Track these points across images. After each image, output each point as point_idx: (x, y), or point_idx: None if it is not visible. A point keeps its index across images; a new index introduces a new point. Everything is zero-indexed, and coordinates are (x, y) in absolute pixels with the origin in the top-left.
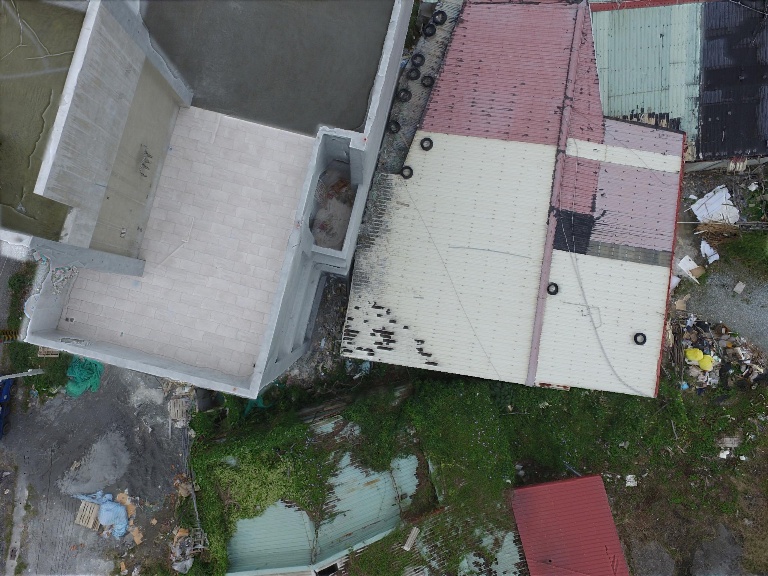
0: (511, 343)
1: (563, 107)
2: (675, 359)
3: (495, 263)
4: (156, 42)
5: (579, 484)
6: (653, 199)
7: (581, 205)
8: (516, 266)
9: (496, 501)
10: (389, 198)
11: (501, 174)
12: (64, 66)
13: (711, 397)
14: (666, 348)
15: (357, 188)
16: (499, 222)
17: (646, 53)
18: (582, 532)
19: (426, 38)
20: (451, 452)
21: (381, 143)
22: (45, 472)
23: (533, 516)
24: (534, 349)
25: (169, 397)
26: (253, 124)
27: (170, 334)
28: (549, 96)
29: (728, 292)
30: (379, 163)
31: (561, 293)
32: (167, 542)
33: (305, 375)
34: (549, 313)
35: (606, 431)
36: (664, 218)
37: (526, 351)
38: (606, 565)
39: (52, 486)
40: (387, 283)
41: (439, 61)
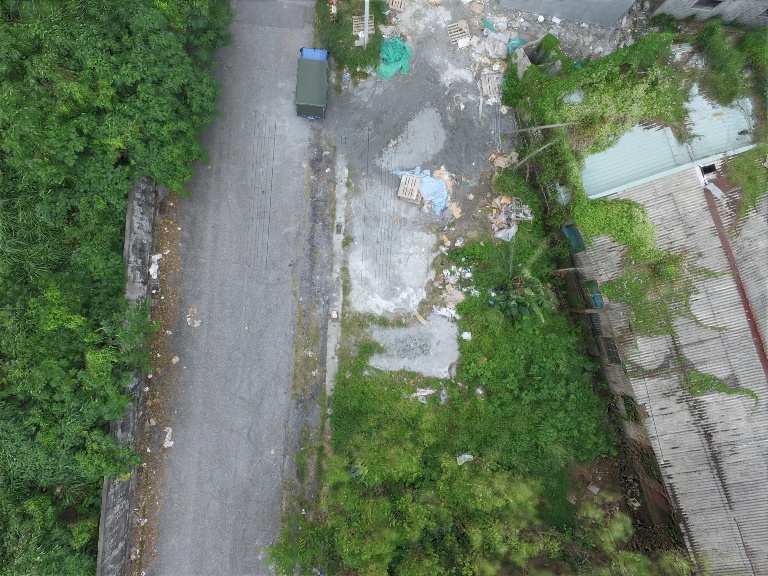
0: None
1: None
2: None
3: None
4: None
5: None
6: None
7: None
8: None
9: None
10: None
11: None
12: None
13: None
14: None
15: None
16: None
17: None
18: None
19: None
20: None
21: None
22: (363, 151)
23: None
24: None
25: (478, 77)
26: None
27: None
28: None
29: None
30: None
31: None
32: (486, 215)
33: None
34: None
35: None
36: None
37: None
38: None
39: (370, 164)
40: None
41: None
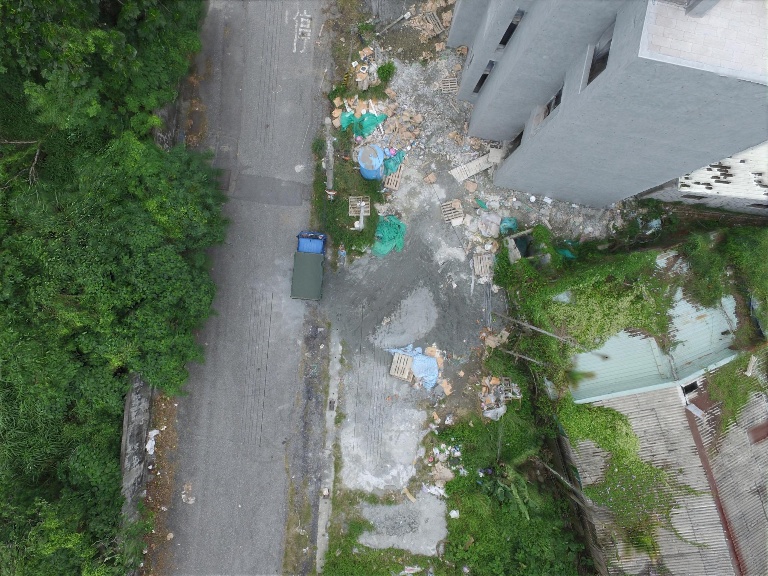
0: None
1: None
2: None
3: None
4: None
5: None
6: None
7: None
8: None
9: None
10: None
11: None
12: None
13: None
14: None
15: None
16: None
17: None
18: None
19: None
20: None
21: None
22: (357, 328)
23: None
24: None
25: (470, 255)
26: None
27: None
28: None
29: None
30: None
31: None
32: (476, 392)
33: (597, 233)
34: None
35: None
36: None
37: None
38: None
39: (364, 341)
40: None
41: None
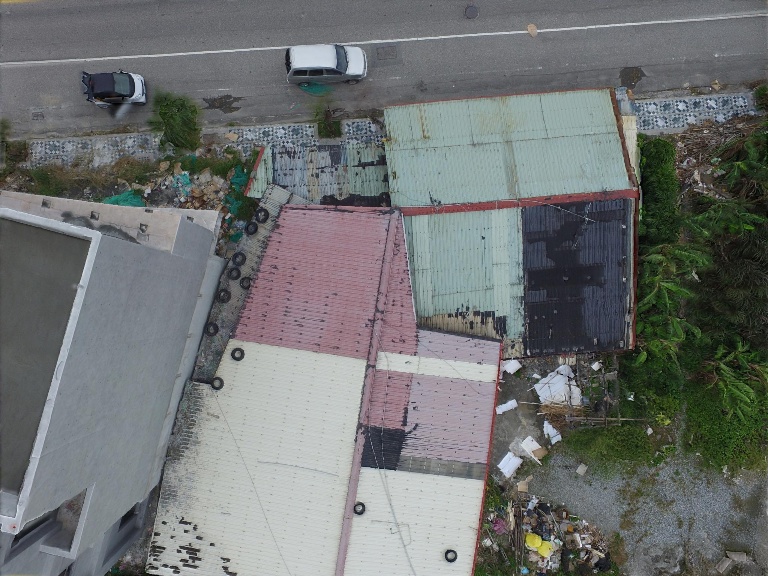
0: (316, 564)
1: (374, 320)
2: (515, 543)
3: (303, 480)
4: None
5: None
6: (468, 410)
7: (391, 420)
8: (323, 484)
9: None
10: (200, 409)
11: (311, 388)
12: None
13: None
14: (507, 531)
15: (86, 488)
16: (307, 438)
17: (468, 254)
18: None
19: (248, 236)
20: None
21: (199, 345)
22: None
23: None
24: (338, 571)
25: None
26: None
27: None
28: (360, 308)
29: (571, 473)
30: (196, 366)
31: (369, 511)
32: None
33: (138, 561)
34: (356, 533)
35: None
36: (479, 429)
37: (331, 573)
38: None
39: None
40: (195, 497)
41: (259, 261)
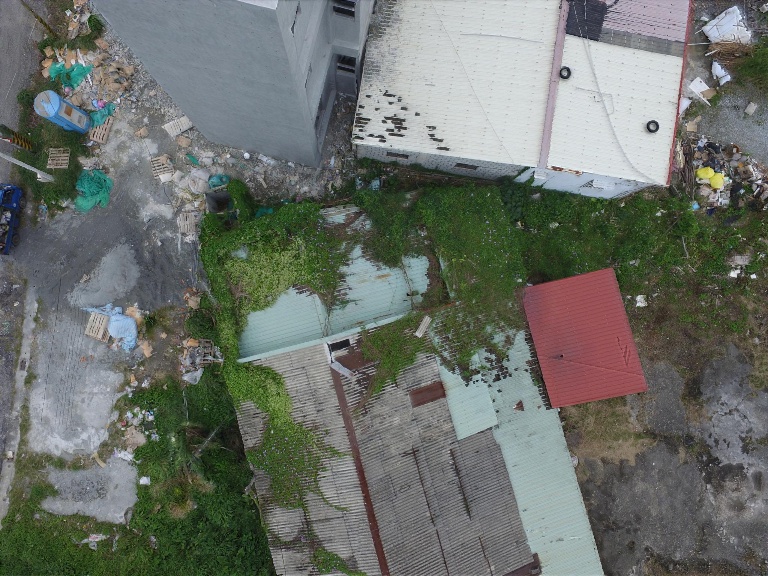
0: (523, 126)
1: None
2: (686, 179)
3: (507, 48)
4: None
5: (591, 277)
6: None
7: None
8: (528, 51)
9: (507, 300)
10: None
11: None
12: None
13: (722, 217)
14: (677, 169)
15: None
16: (511, 8)
17: None
18: (594, 325)
19: None
20: (462, 248)
21: None
22: (55, 285)
23: (545, 312)
24: (546, 131)
25: (178, 213)
26: None
27: None
28: None
29: (739, 114)
30: None
31: (573, 78)
32: (177, 355)
33: (315, 193)
34: (561, 97)
35: (617, 249)
36: (677, 8)
37: (538, 134)
38: (618, 356)
39: (62, 299)
40: (398, 71)
41: None
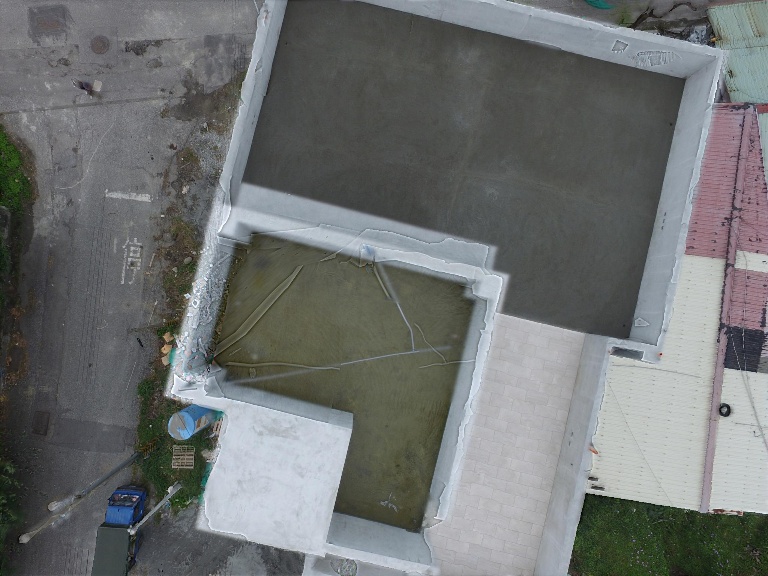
0: (682, 467)
1: (731, 218)
2: None
3: (663, 383)
4: (409, 232)
5: None
6: None
7: (751, 320)
8: (685, 386)
9: None
10: None
11: None
12: (465, 377)
13: None
14: None
15: None
16: (666, 339)
17: None
18: None
19: None
20: (611, 573)
21: None
22: None
23: None
24: (707, 474)
25: None
26: (513, 318)
27: (432, 546)
28: (716, 206)
29: None
30: None
31: (733, 414)
32: None
33: None
34: (721, 435)
35: (755, 537)
36: None
37: (699, 476)
38: None
39: None
40: None
41: None
